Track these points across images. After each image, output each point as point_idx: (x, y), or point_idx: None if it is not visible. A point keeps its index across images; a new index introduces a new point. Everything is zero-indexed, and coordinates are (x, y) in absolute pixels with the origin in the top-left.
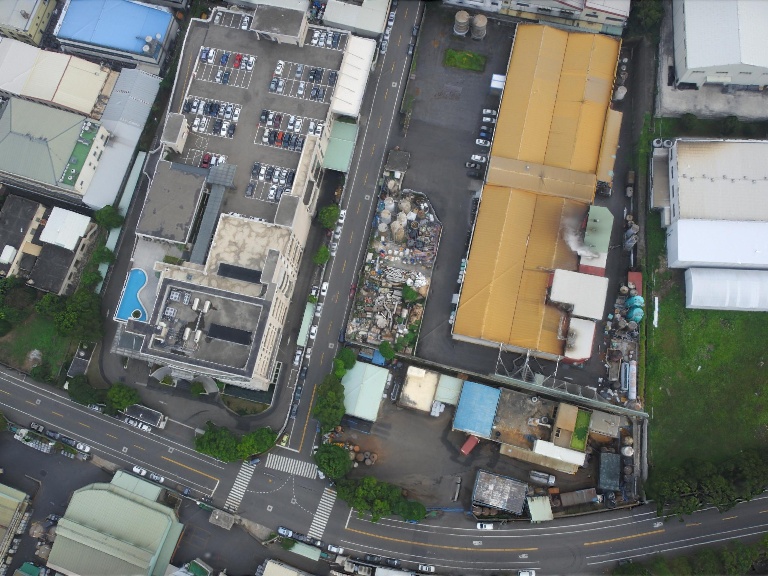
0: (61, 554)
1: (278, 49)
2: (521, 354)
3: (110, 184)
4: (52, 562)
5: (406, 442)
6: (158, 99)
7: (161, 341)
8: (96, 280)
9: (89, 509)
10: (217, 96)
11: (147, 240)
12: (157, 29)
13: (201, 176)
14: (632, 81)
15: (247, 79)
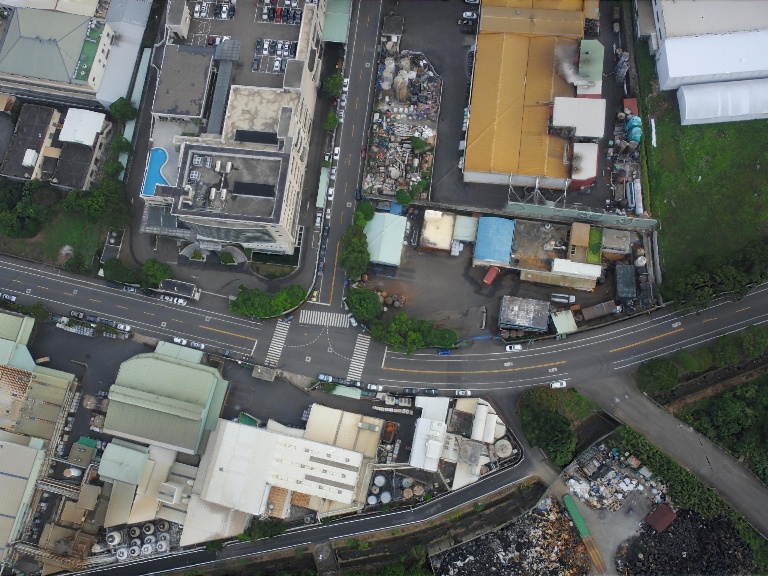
0: (116, 419)
1: None
2: (530, 186)
3: (120, 81)
4: (108, 427)
5: (430, 283)
6: None
7: (189, 203)
8: (118, 169)
9: (137, 375)
10: None
11: (163, 121)
12: None
13: (208, 54)
14: None
15: None
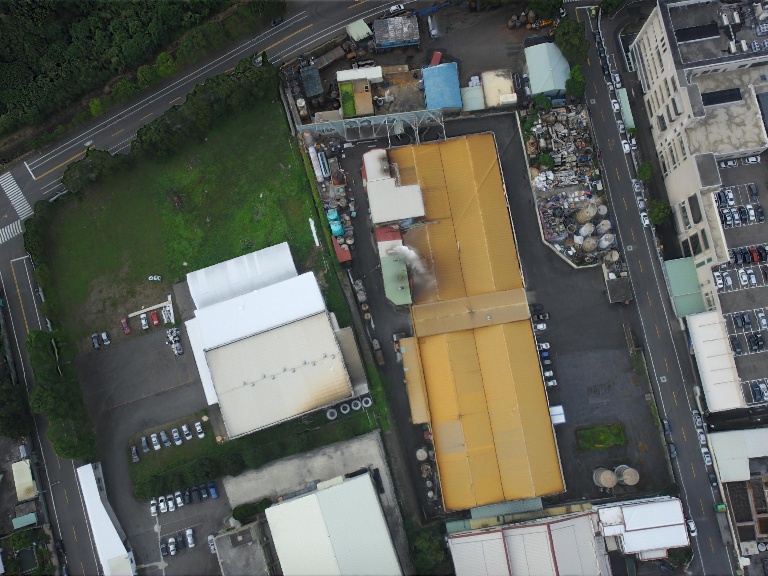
0: None
1: None
2: None
3: None
4: None
5: (489, 48)
6: None
7: (756, 3)
8: None
9: None
10: None
11: None
12: None
13: None
14: (414, 477)
15: None
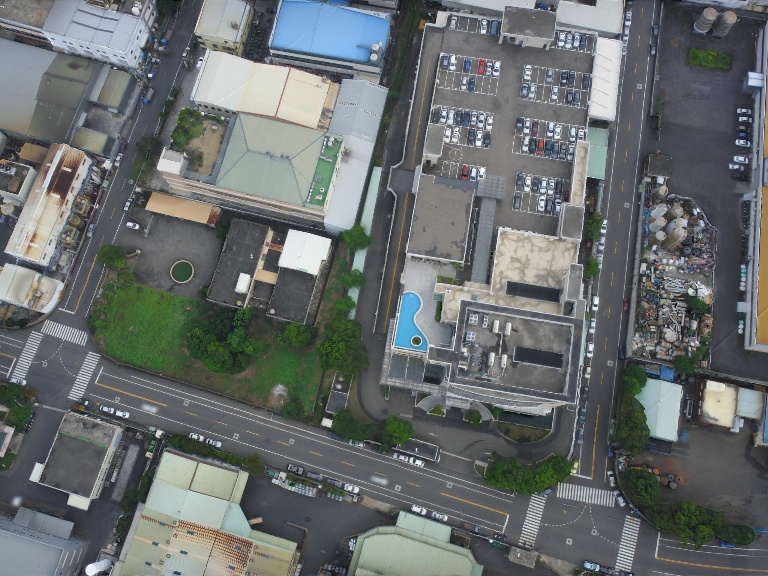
0: None
1: (522, 53)
2: None
3: (349, 203)
4: None
5: (708, 461)
6: (387, 110)
7: (464, 369)
8: (351, 306)
9: (382, 556)
10: (465, 104)
11: (415, 260)
12: (377, 37)
13: (469, 189)
14: None
15: (494, 86)
